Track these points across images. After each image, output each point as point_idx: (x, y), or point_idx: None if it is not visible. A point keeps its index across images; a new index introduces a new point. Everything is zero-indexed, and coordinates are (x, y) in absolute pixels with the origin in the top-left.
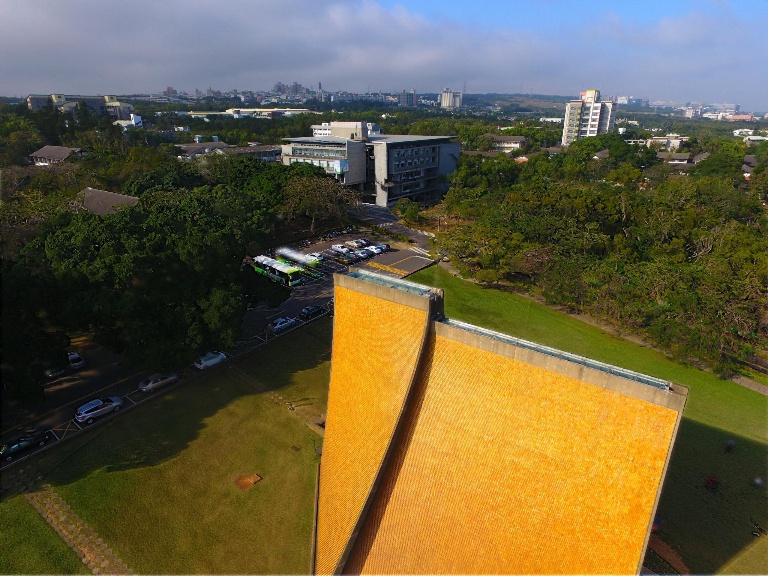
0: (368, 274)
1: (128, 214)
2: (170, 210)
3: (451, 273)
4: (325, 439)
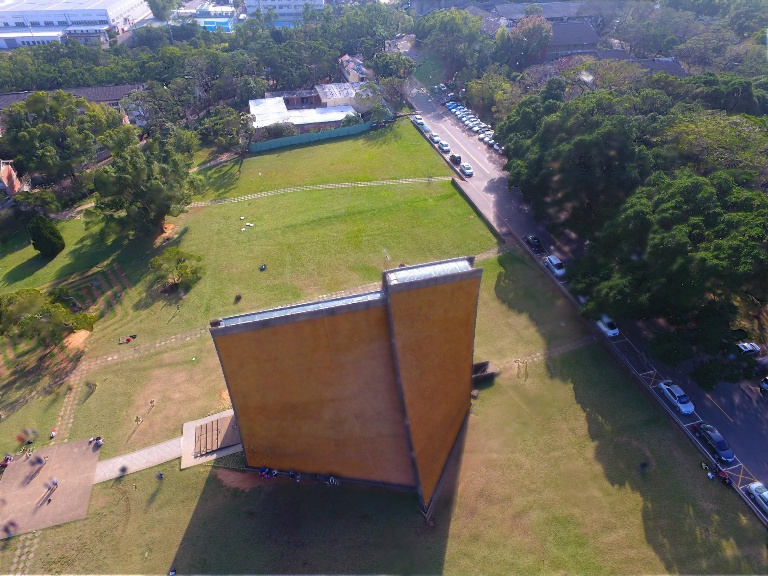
0: None
1: (742, 198)
2: (760, 220)
3: None
4: None
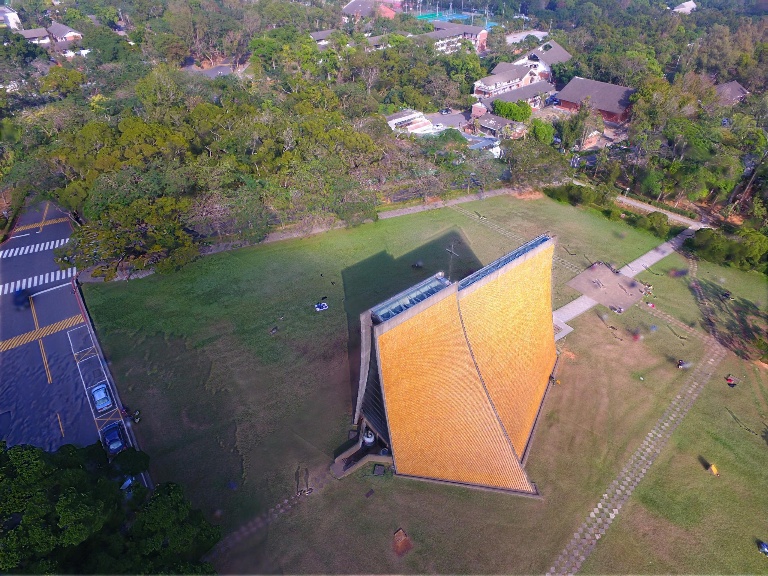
0: (384, 306)
1: None
2: None
3: (119, 280)
4: (401, 451)
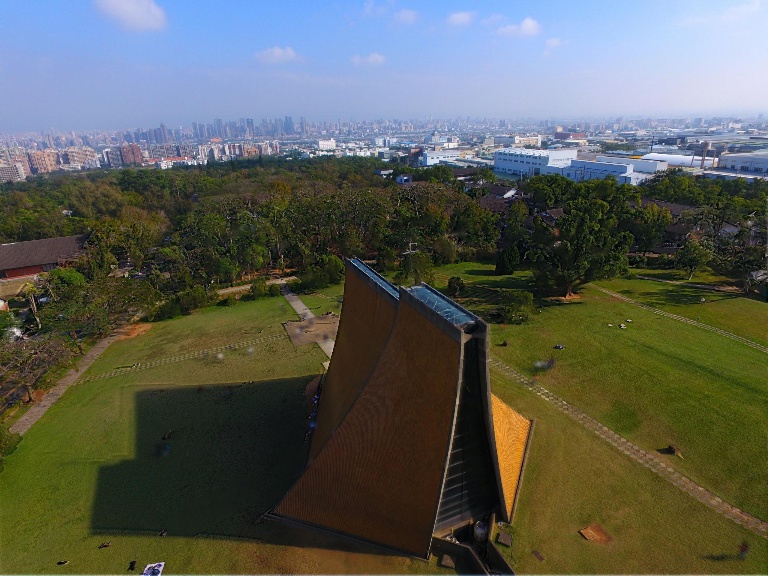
0: None
1: None
2: None
3: None
4: None
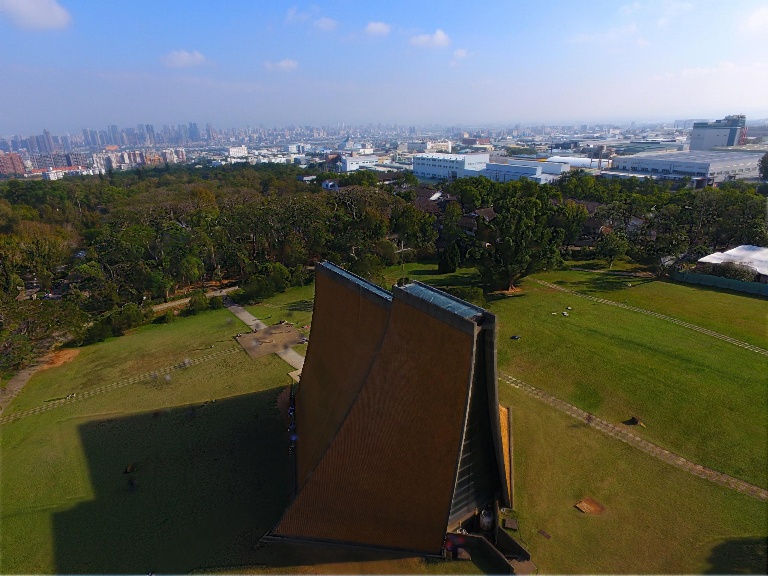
0: None
1: None
2: None
3: None
4: None
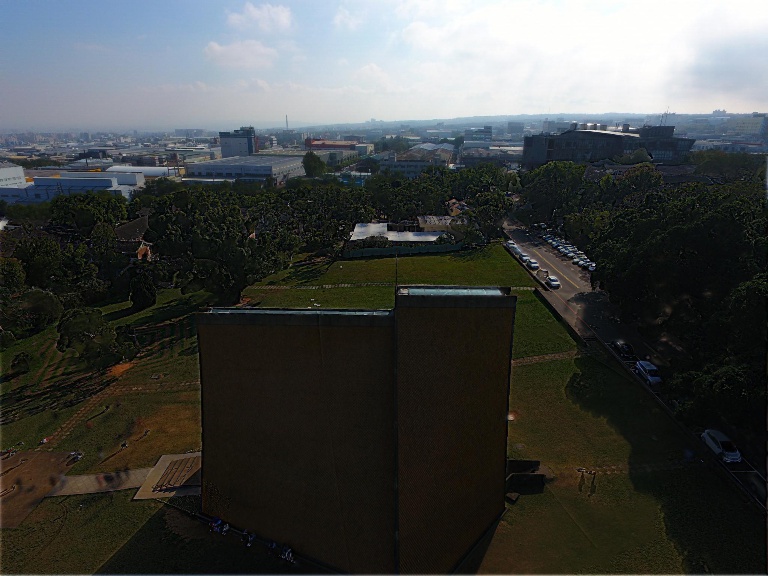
0: None
1: None
2: None
3: None
4: None
